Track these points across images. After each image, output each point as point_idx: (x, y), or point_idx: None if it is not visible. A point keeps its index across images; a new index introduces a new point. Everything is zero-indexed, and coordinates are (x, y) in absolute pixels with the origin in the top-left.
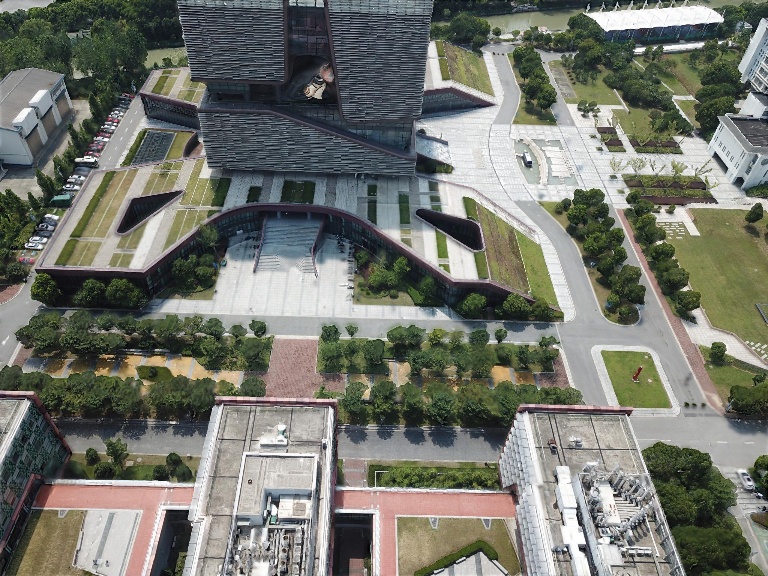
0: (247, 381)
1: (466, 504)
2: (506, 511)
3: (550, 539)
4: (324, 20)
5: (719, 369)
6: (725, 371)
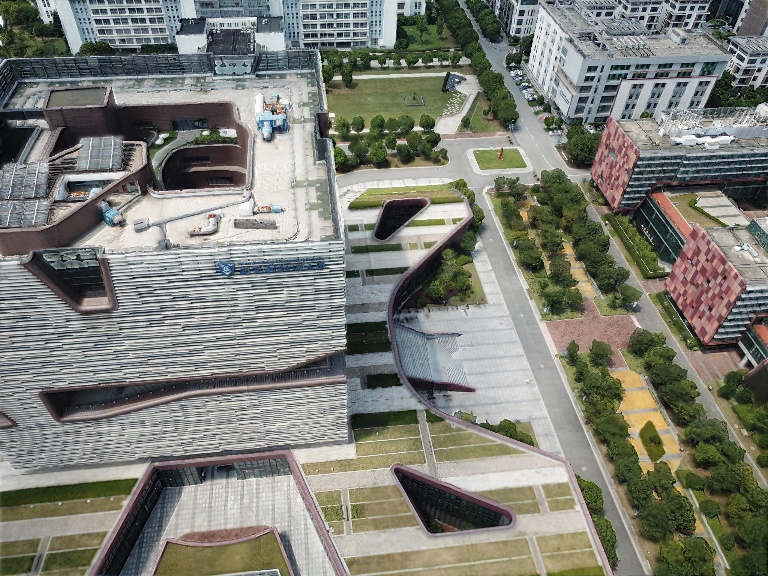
0: (643, 340)
1: (670, 211)
2: (662, 196)
3: None
4: None
5: (474, 128)
6: (475, 126)
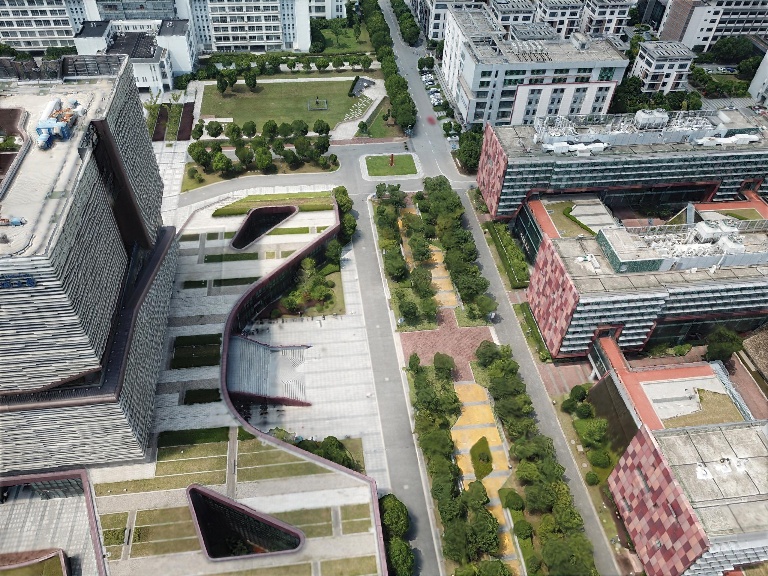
0: (487, 353)
1: (543, 219)
2: (538, 204)
3: (586, 155)
4: (104, 154)
5: (373, 133)
6: (374, 131)
